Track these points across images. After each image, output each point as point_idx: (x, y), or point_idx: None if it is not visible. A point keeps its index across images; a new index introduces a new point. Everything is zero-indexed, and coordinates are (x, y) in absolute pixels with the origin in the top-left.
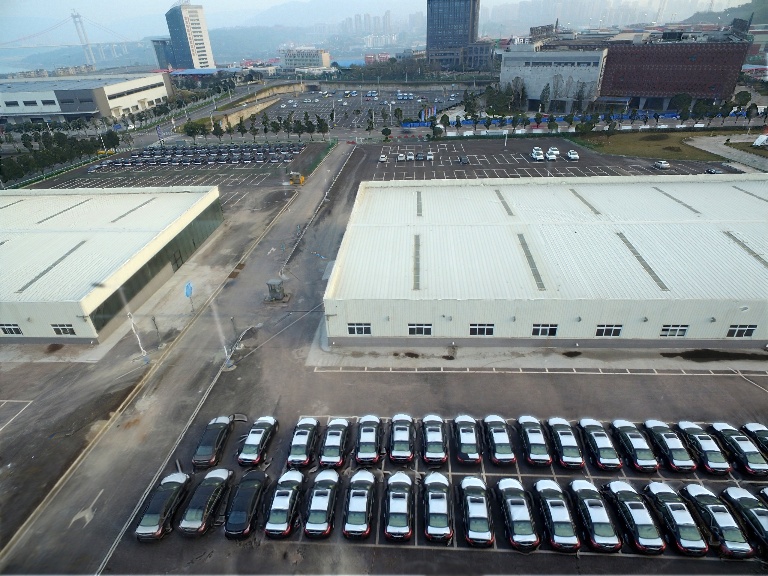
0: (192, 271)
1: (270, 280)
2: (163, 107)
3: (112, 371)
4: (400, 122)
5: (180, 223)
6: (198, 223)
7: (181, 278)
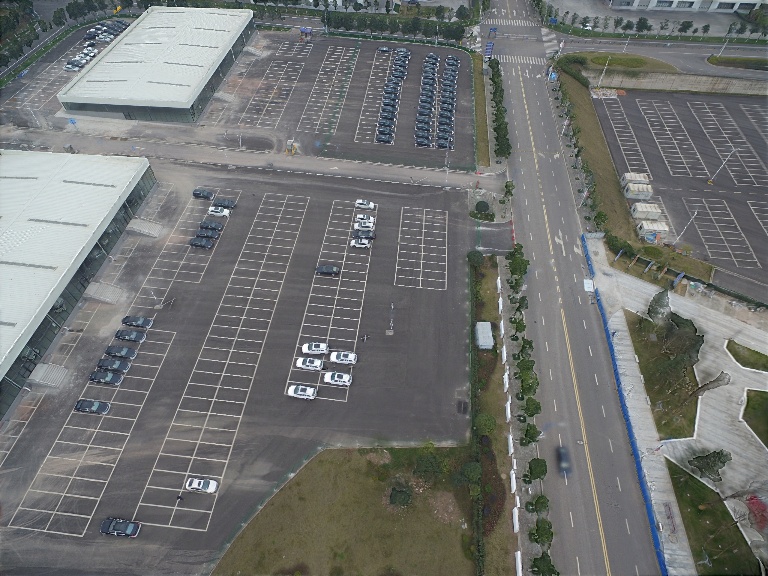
0: (127, 124)
1: (69, 144)
2: (642, 22)
3: (43, 120)
4: (603, 232)
5: (135, 102)
6: (157, 110)
7: (120, 122)
